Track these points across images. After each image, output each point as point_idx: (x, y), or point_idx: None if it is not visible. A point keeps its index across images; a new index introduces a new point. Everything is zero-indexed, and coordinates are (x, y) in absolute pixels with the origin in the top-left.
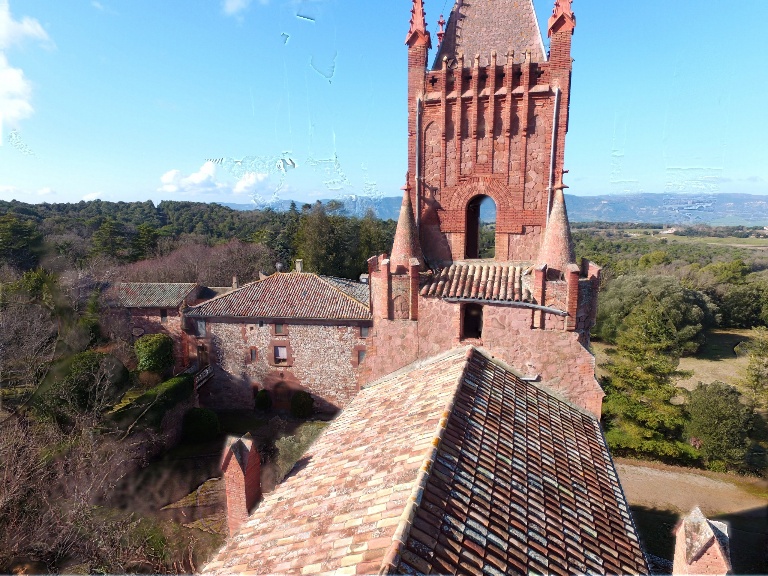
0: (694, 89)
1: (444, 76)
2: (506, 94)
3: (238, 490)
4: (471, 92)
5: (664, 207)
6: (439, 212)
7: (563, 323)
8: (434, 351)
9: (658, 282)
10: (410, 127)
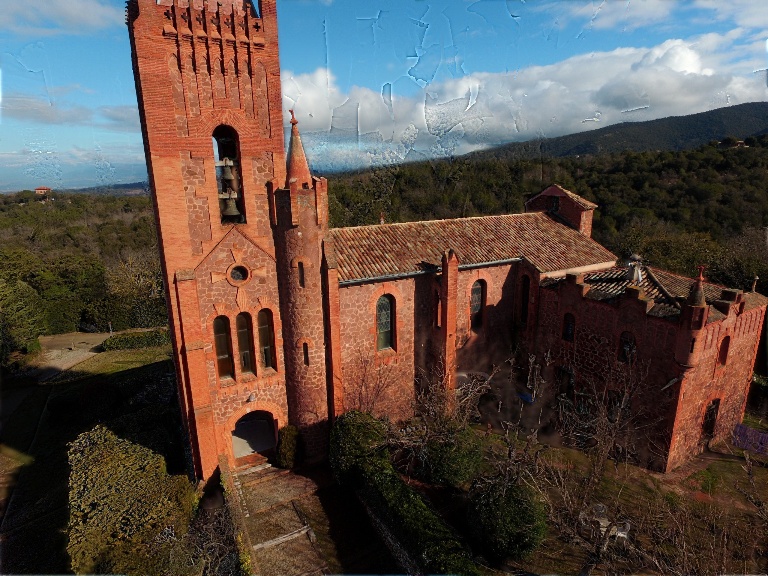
0: None
1: None
2: None
3: None
4: None
5: None
6: None
7: None
8: None
9: None
10: None
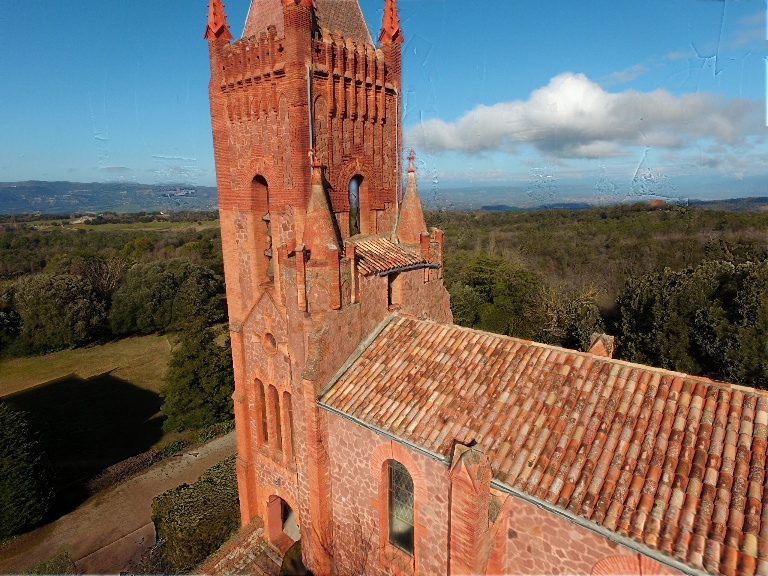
0: (158, 83)
1: (330, 50)
2: (372, 84)
3: (484, 502)
4: (350, 74)
5: (158, 194)
6: (330, 192)
7: (437, 274)
8: (372, 327)
9: (175, 264)
10: (301, 96)
